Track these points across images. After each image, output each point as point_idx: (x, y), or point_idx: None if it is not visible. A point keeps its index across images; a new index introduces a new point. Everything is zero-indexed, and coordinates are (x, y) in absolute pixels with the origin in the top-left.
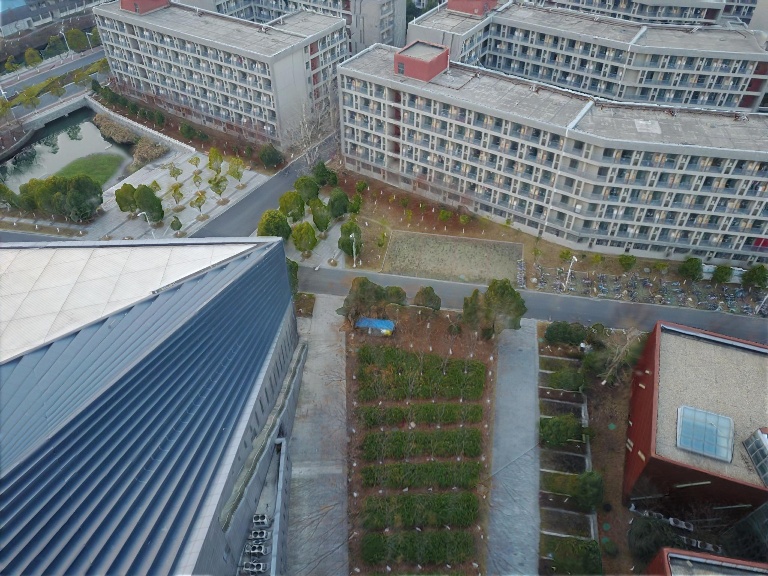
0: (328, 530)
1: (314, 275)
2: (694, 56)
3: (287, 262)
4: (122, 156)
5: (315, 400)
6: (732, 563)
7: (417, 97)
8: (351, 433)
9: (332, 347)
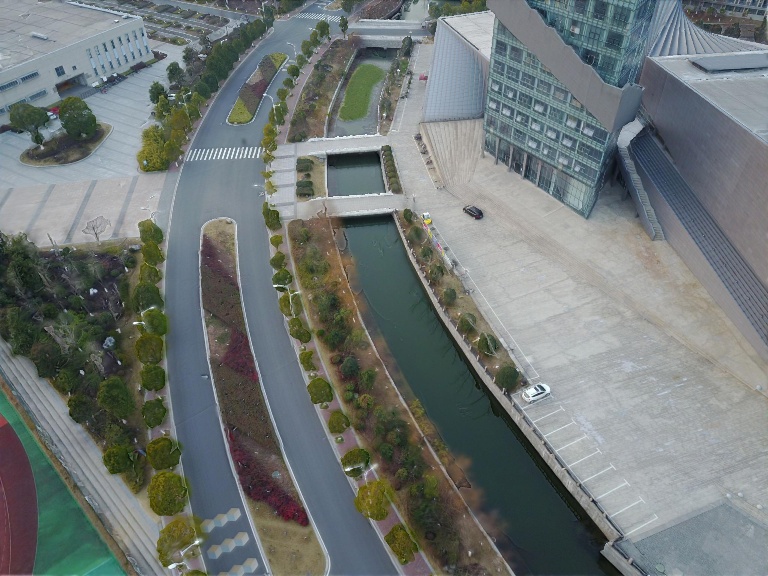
0: None
1: None
2: None
3: None
4: None
5: None
6: None
7: None
8: None
9: None
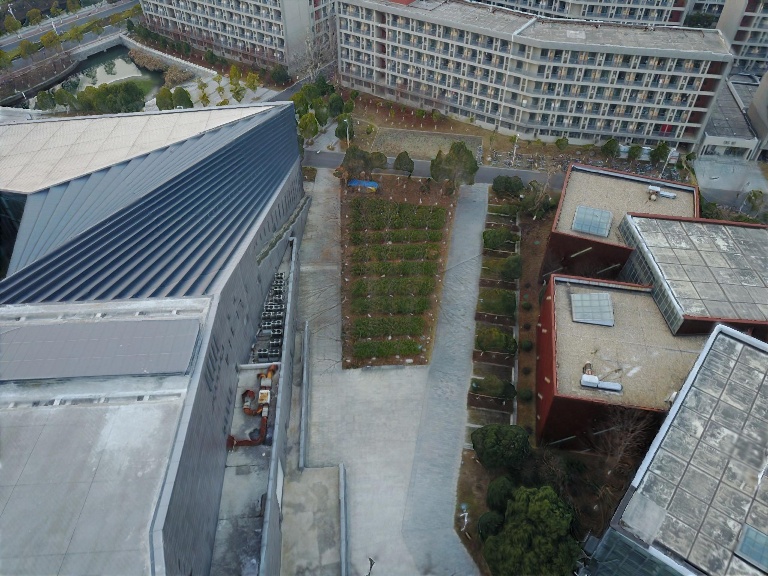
0: (327, 298)
1: (316, 156)
2: None
3: None
4: (155, 80)
5: (317, 230)
6: (596, 281)
7: (398, 17)
8: (344, 248)
9: (330, 199)
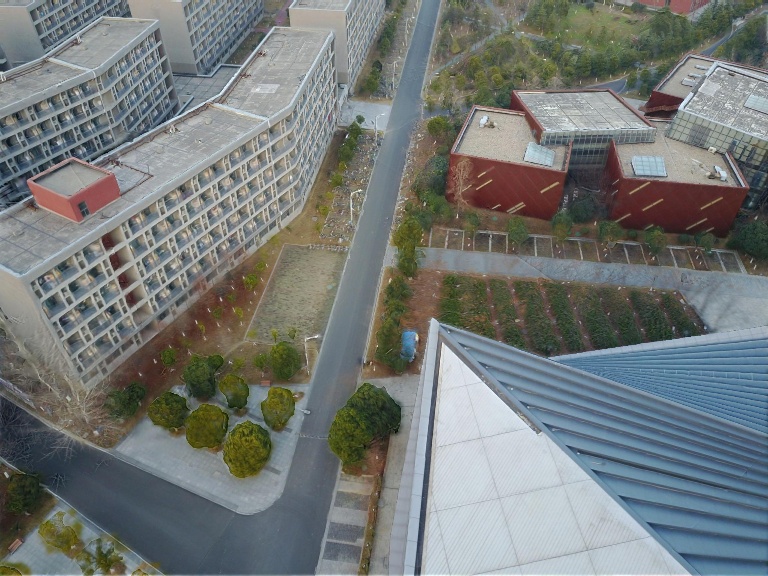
0: None
1: (319, 413)
2: (128, 52)
3: (369, 388)
4: None
5: None
6: None
7: (138, 215)
8: None
9: None
